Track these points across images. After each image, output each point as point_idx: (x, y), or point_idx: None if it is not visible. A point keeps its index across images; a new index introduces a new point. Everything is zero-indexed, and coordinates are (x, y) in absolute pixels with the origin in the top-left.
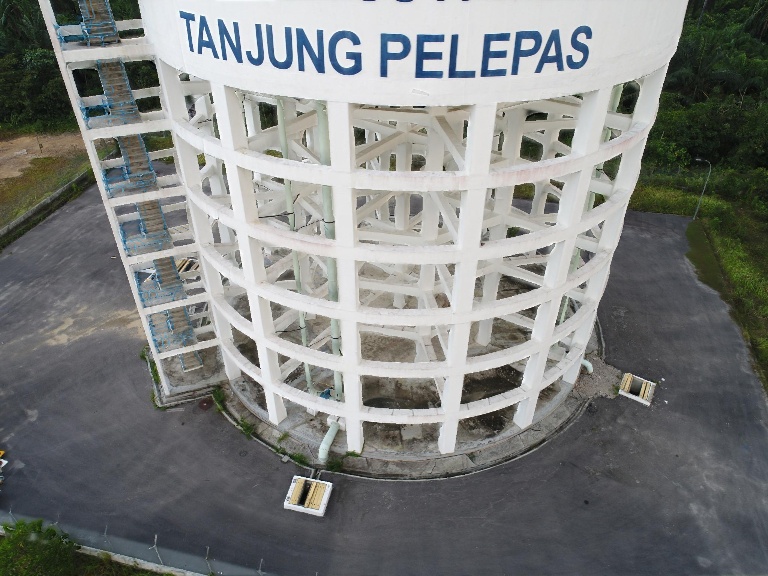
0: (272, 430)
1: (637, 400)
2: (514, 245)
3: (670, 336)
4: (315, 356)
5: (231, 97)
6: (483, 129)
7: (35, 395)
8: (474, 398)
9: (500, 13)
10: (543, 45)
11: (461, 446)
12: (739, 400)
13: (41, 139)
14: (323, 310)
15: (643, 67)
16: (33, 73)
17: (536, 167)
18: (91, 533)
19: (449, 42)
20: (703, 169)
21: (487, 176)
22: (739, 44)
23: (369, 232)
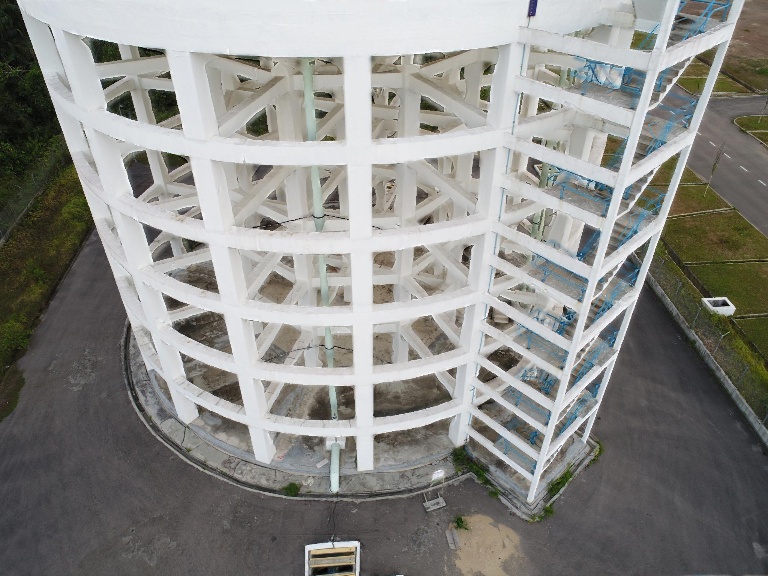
0: None
1: None
2: None
3: None
4: None
5: None
6: None
7: None
8: None
9: None
10: None
11: None
12: None
13: None
14: None
15: None
16: None
17: None
18: (736, 429)
19: None
20: None
21: None
22: None
23: None
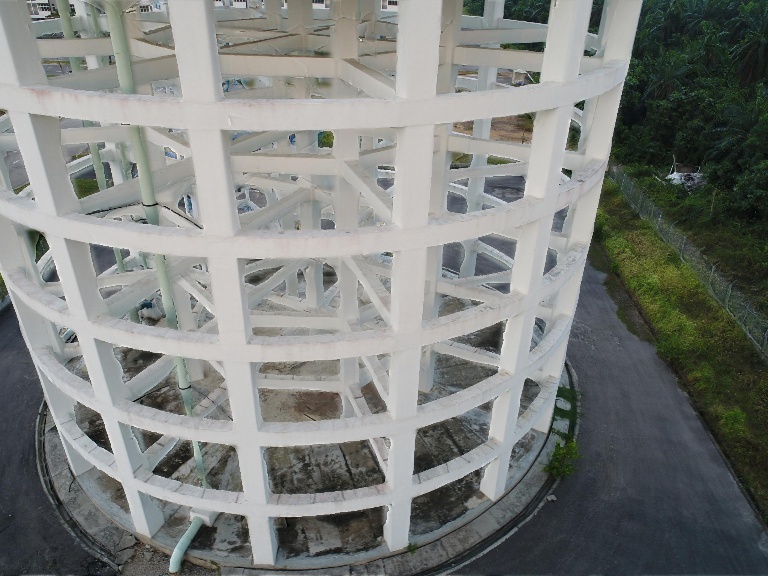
0: None
1: None
2: None
3: None
4: None
5: None
6: None
7: None
8: None
9: None
10: None
11: None
12: None
13: None
14: None
15: None
16: None
17: None
18: None
19: None
20: None
21: None
22: None
23: None
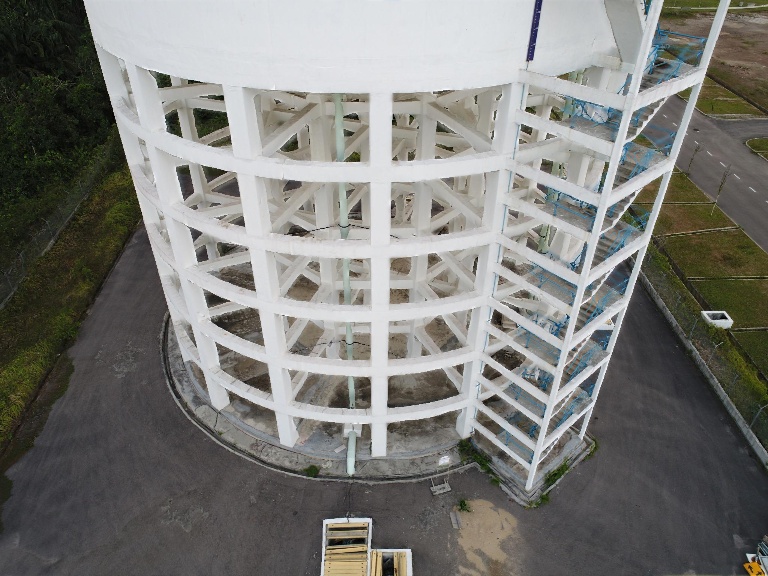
0: None
1: None
2: None
3: None
4: None
5: None
6: None
7: None
8: None
9: None
10: None
11: None
12: None
13: None
14: None
15: None
16: None
17: None
18: (725, 432)
19: None
20: None
21: None
22: None
23: None
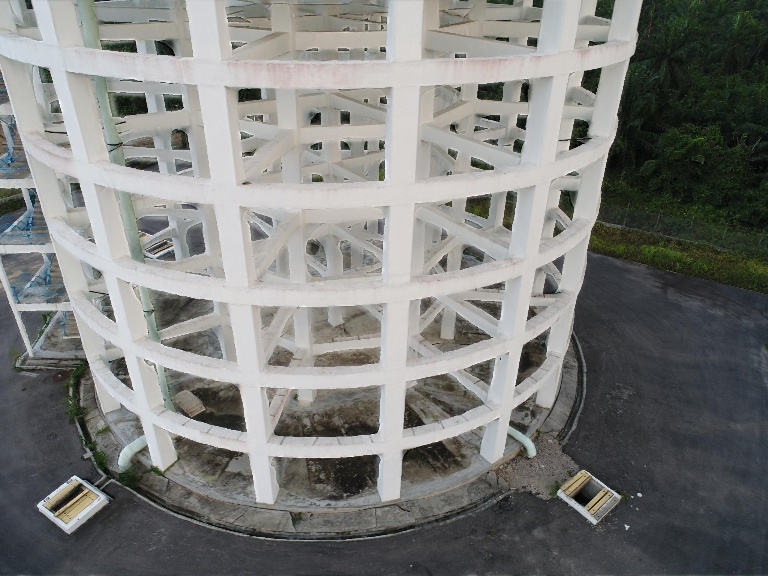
0: (99, 420)
1: (580, 511)
2: (291, 192)
3: (684, 440)
4: (98, 322)
5: None
6: None
7: None
8: None
9: None
10: None
11: (287, 499)
12: (754, 559)
13: None
14: (86, 255)
15: None
16: None
17: (300, 63)
18: None
19: None
20: None
21: (220, 65)
22: None
23: None
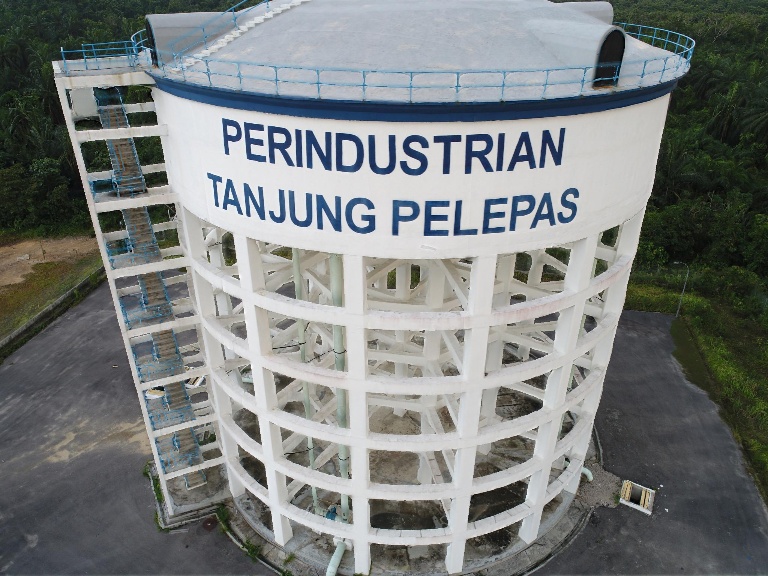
0: (278, 551)
1: (638, 509)
2: (516, 374)
3: (664, 439)
4: (324, 480)
5: (252, 246)
6: (485, 276)
7: (35, 518)
8: (478, 511)
9: (498, 182)
10: (537, 206)
11: (468, 565)
12: (737, 506)
13: (43, 243)
14: (334, 437)
15: (625, 214)
16: (39, 181)
17: (534, 306)
18: None
19: (454, 207)
20: (680, 265)
21: (490, 316)
22: (703, 145)
23: (374, 352)
